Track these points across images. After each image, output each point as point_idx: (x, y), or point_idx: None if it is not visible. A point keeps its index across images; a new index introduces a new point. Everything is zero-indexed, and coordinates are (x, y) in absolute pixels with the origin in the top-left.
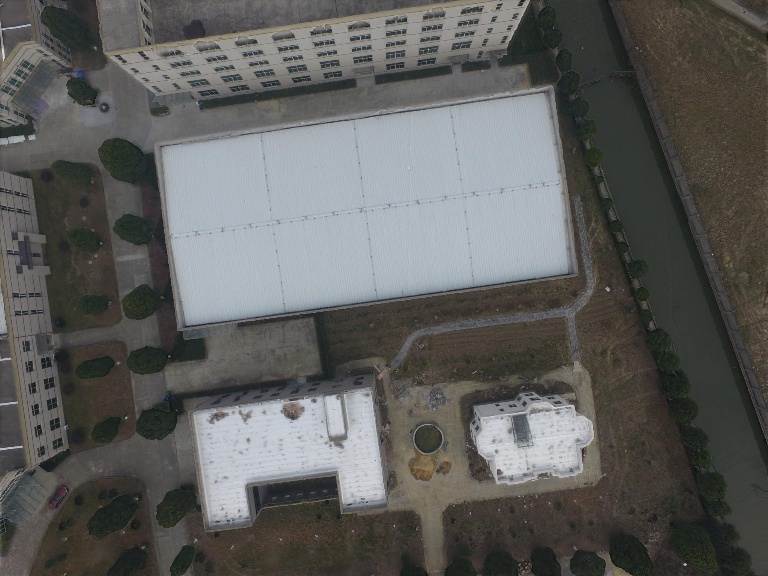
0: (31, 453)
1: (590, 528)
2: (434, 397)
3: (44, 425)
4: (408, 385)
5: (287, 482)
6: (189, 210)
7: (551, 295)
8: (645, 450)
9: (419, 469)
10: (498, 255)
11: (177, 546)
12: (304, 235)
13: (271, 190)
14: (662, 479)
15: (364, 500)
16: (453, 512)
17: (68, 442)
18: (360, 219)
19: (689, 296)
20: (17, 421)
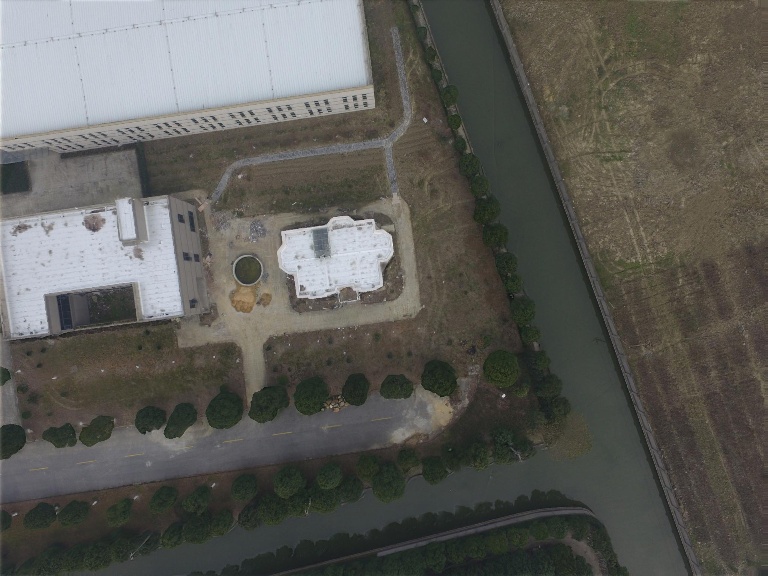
0: None
1: (409, 360)
2: (254, 229)
3: None
4: (229, 217)
5: (109, 314)
6: None
7: (369, 126)
8: (463, 281)
9: (239, 301)
10: (297, 68)
11: None
12: (105, 48)
13: (74, 4)
14: (480, 310)
15: (164, 312)
16: (273, 344)
17: None
18: (160, 32)
19: (515, 135)
20: None
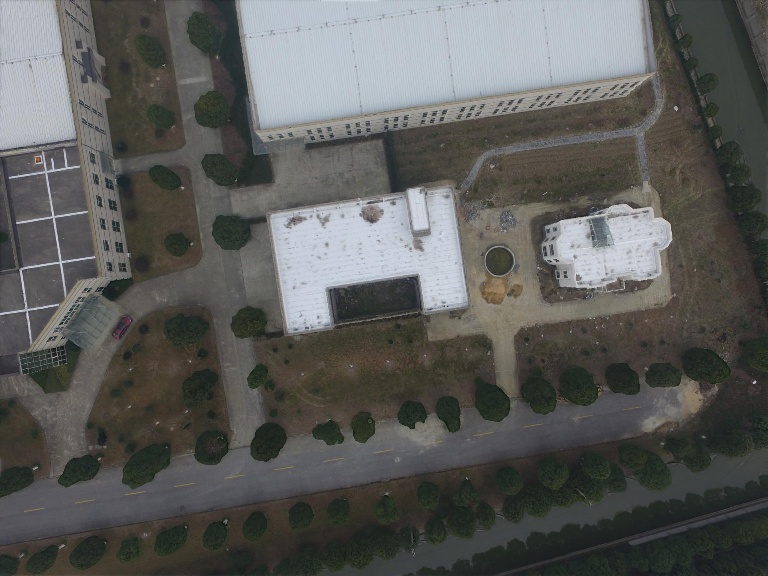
0: (101, 263)
1: (661, 348)
2: (505, 219)
3: (110, 243)
4: (478, 207)
5: (357, 308)
6: (263, 10)
7: (620, 114)
8: (714, 269)
9: (490, 292)
10: (576, 55)
11: (245, 376)
12: (381, 34)
13: None
14: (731, 298)
15: (445, 304)
16: (525, 335)
17: (131, 271)
18: (438, 18)
19: (752, 123)
20: (85, 231)
